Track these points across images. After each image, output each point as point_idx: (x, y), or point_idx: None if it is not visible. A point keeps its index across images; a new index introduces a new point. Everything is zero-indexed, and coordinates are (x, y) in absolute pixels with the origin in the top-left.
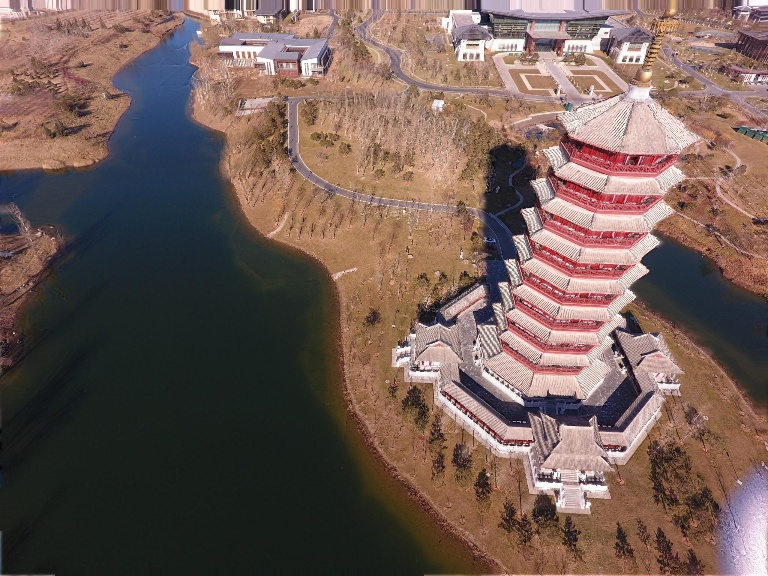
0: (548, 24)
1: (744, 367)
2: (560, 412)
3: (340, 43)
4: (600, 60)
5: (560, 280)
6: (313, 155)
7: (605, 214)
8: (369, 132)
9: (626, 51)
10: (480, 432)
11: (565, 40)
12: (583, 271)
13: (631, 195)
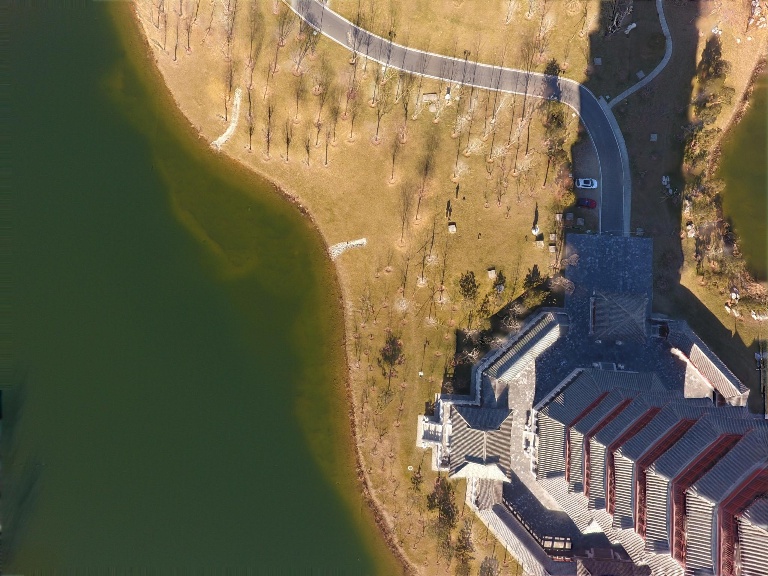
0: None
1: None
2: None
3: None
4: None
5: None
6: None
7: None
8: None
9: None
10: None
11: None
12: None
13: None
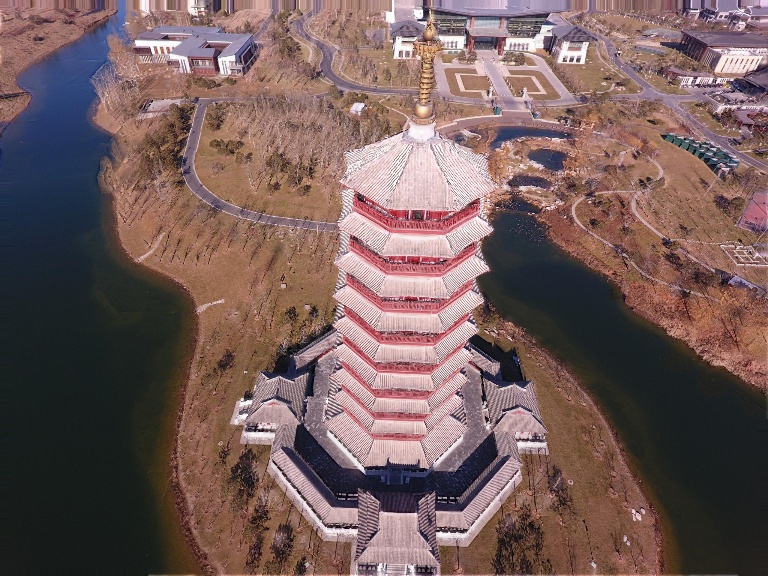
0: (488, 21)
1: (629, 413)
2: (405, 481)
3: (271, 38)
4: (541, 59)
5: (370, 345)
6: (208, 165)
7: (398, 275)
8: (275, 139)
9: (566, 50)
10: (307, 510)
11: (506, 38)
12: (391, 337)
13: (417, 256)
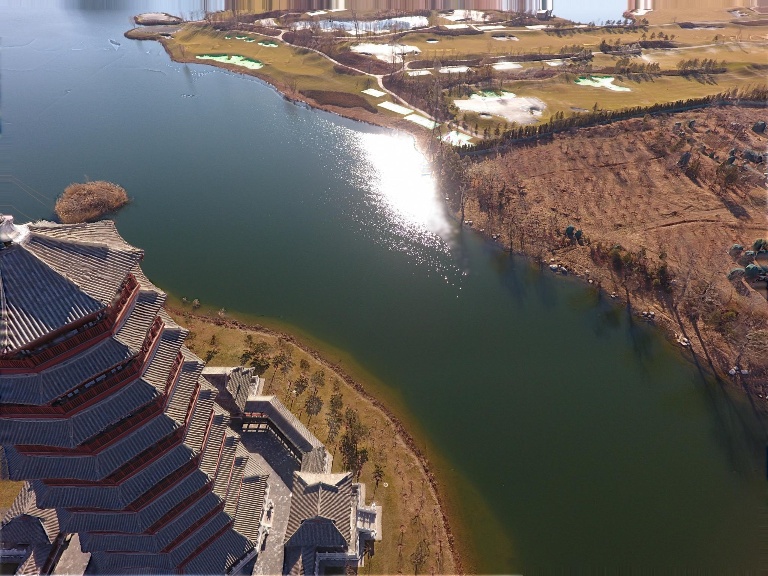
0: None
1: None
2: None
3: None
4: None
5: None
6: None
7: None
8: None
9: None
10: None
11: None
12: None
13: None
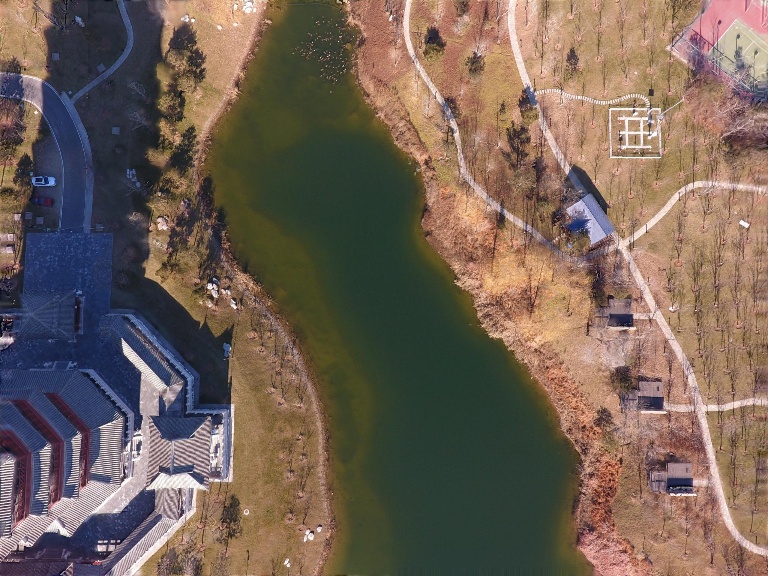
0: None
1: (357, 407)
2: None
3: None
4: None
5: None
6: None
7: None
8: None
9: None
10: None
11: None
12: None
13: None
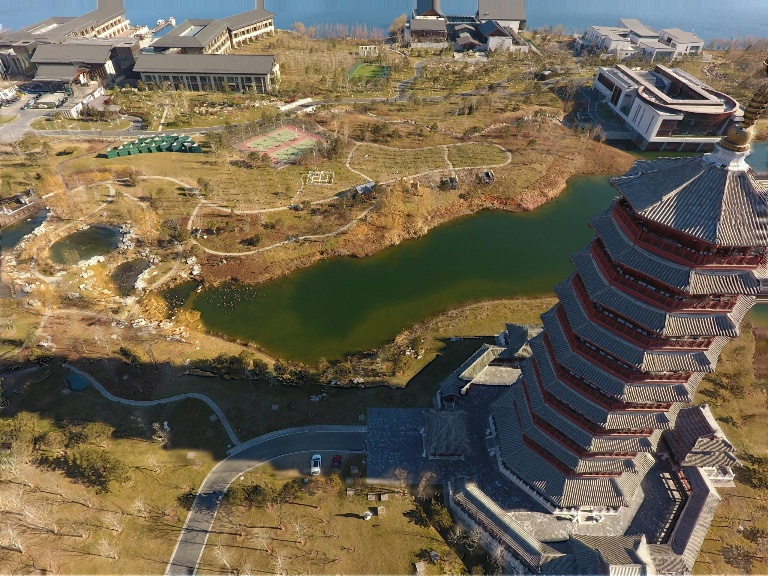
0: None
1: (480, 288)
2: None
3: None
4: None
5: None
6: None
7: None
8: None
9: None
10: None
11: None
12: None
13: None
